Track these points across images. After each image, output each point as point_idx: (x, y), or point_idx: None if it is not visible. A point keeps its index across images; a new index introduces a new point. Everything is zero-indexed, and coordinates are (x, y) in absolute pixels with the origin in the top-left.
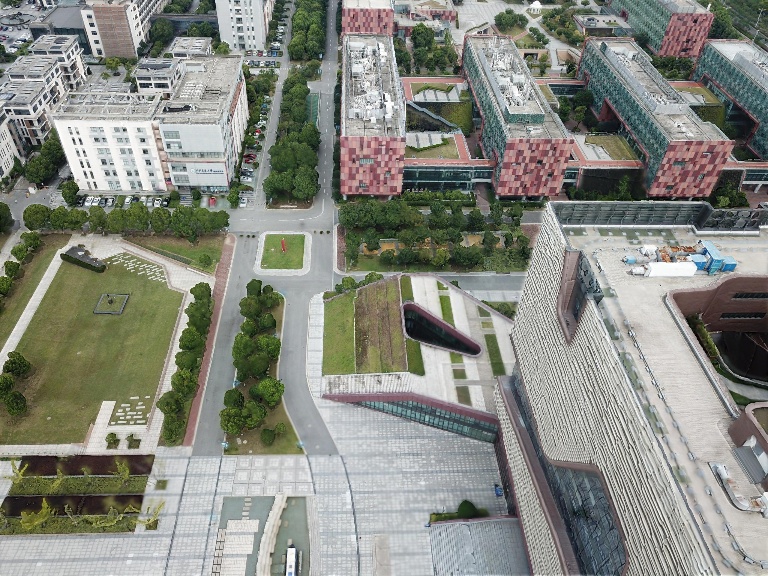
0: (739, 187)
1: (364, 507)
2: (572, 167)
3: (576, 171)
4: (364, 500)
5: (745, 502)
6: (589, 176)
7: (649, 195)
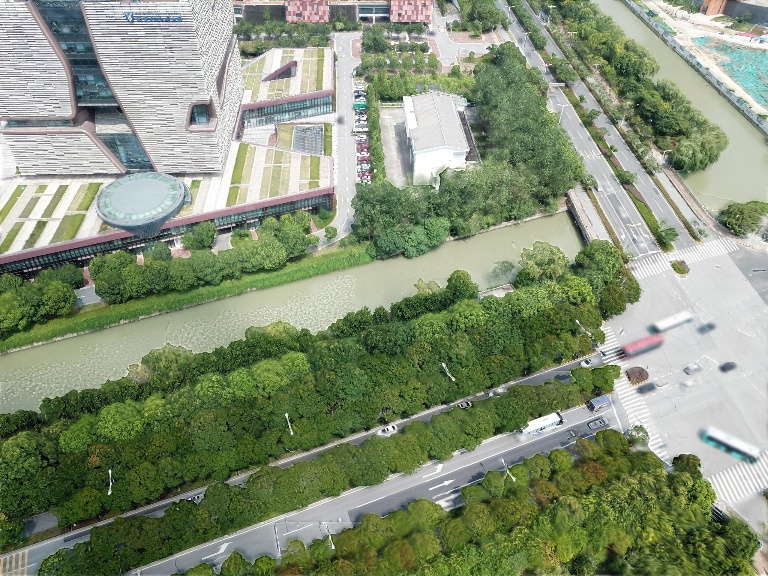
0: (356, 18)
1: (1, 142)
2: (236, 5)
3: (240, 8)
4: (3, 140)
5: (4, 1)
6: (249, 11)
7: (287, 22)
